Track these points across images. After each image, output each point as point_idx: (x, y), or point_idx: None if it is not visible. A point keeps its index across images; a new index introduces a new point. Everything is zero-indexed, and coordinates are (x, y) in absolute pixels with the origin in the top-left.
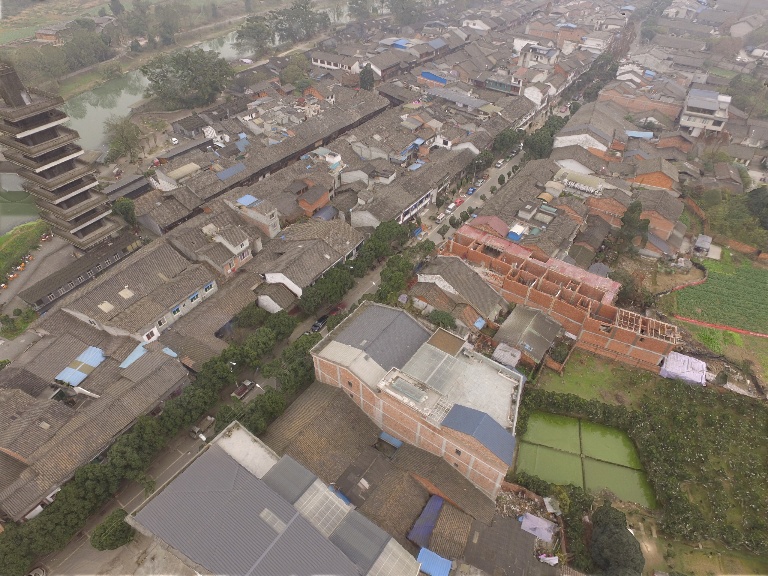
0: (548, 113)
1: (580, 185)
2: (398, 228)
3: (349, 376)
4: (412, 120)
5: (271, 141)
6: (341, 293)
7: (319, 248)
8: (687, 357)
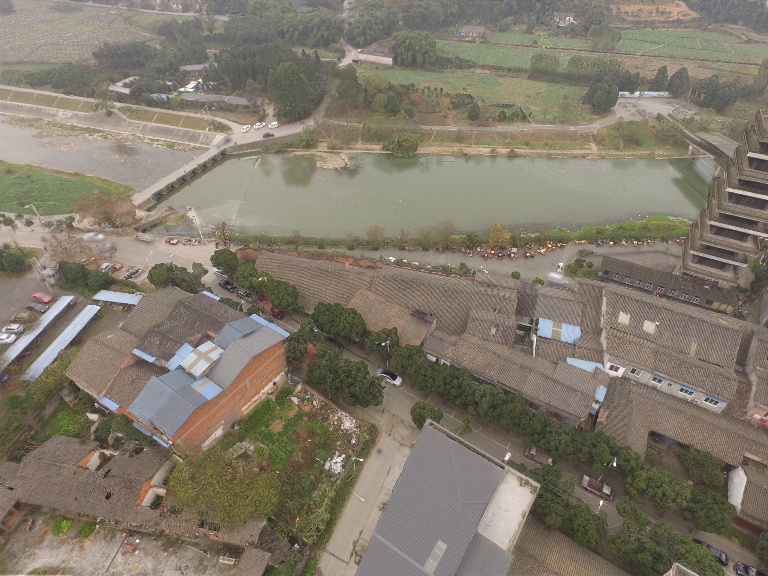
0: None
1: None
2: None
3: None
4: None
5: None
6: None
7: None
8: None
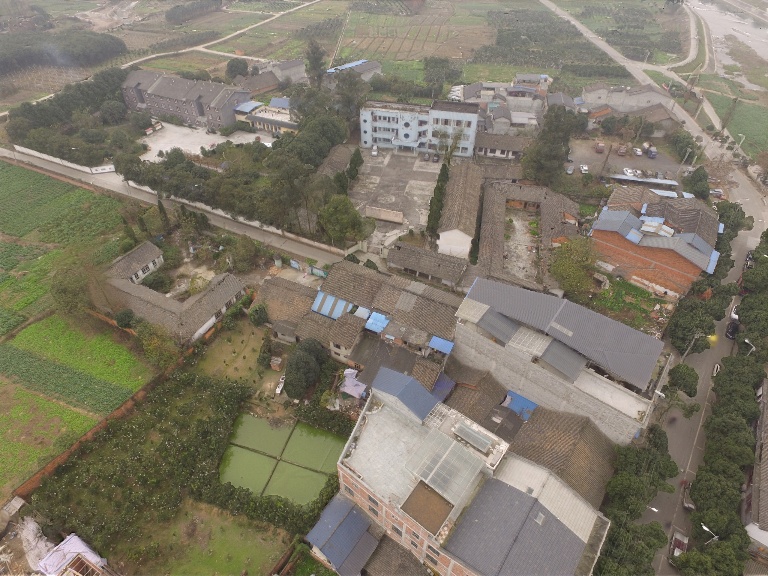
0: None
1: None
2: None
3: None
4: None
5: None
6: None
7: None
8: (54, 575)
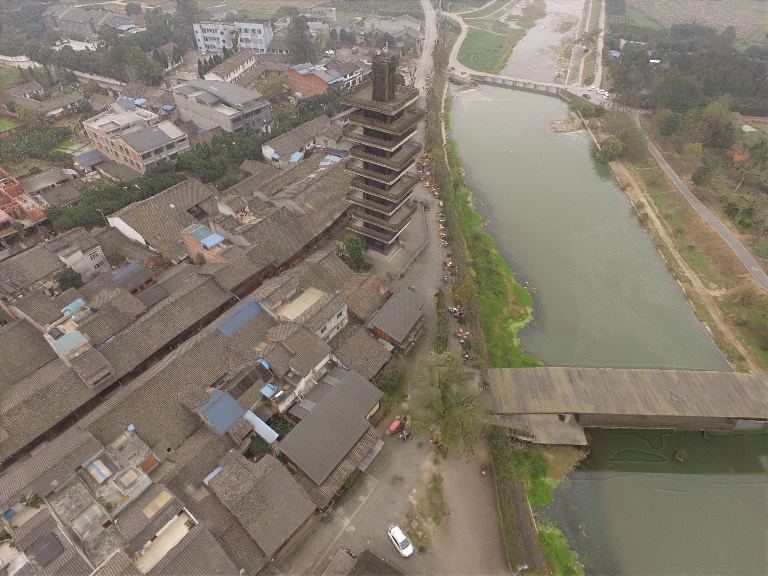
0: None
1: None
2: None
3: None
4: None
5: None
6: None
7: None
8: None
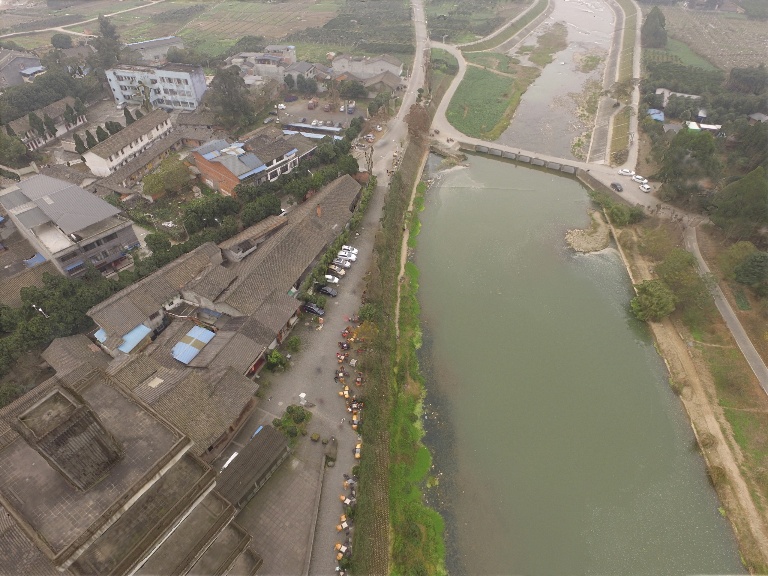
0: None
1: None
2: None
3: None
4: None
5: None
6: None
7: None
8: None
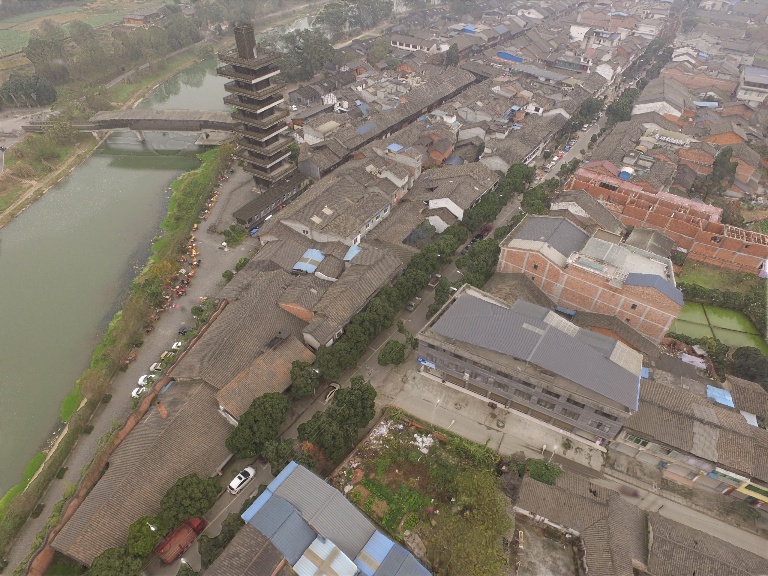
0: (616, 89)
1: (671, 139)
2: (528, 169)
3: (538, 259)
4: (506, 90)
5: (384, 107)
6: (495, 214)
7: (469, 182)
8: None
